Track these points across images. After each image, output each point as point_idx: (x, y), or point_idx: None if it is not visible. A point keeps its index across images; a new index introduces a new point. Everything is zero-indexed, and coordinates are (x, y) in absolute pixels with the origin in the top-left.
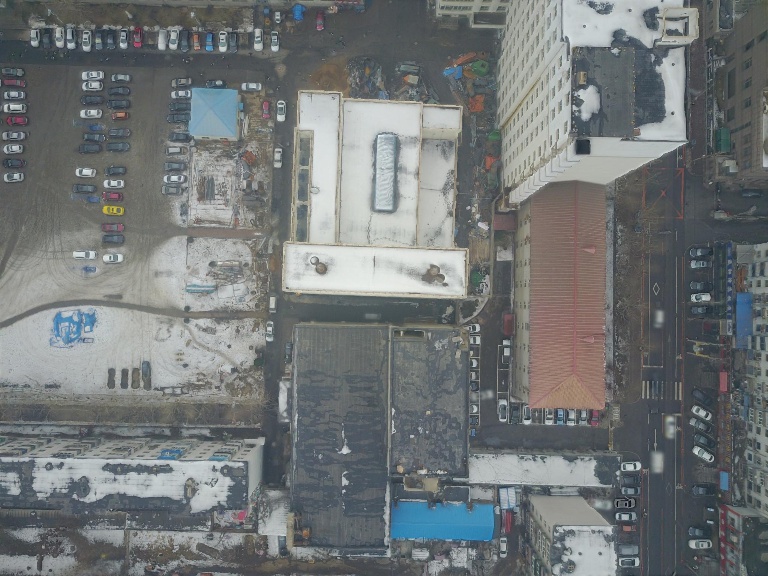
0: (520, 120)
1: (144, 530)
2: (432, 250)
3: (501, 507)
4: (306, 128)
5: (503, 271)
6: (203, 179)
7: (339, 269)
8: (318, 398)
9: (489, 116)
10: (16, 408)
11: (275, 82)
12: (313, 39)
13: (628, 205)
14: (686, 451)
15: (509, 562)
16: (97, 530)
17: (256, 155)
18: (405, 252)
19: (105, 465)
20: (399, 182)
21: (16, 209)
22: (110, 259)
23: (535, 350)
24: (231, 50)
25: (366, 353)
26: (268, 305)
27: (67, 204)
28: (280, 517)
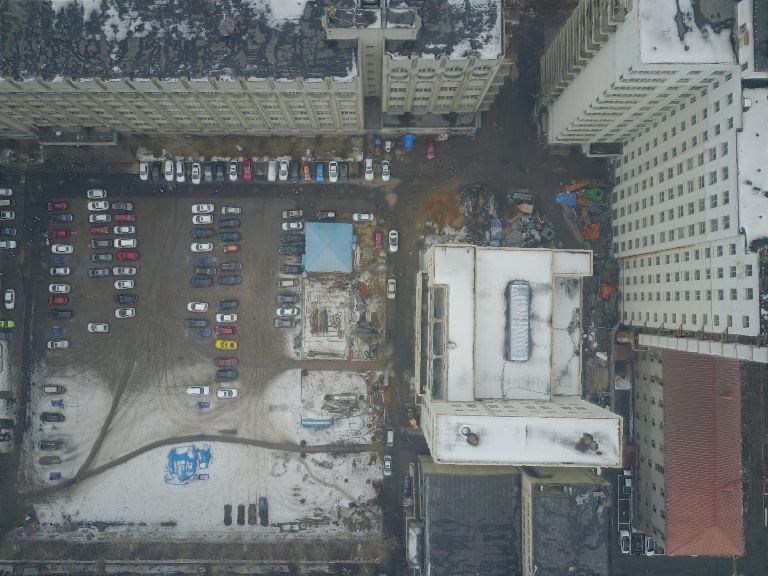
0: (655, 267)
1: None
2: (585, 419)
3: None
4: (441, 282)
5: (621, 400)
6: (316, 311)
7: (491, 439)
8: (451, 547)
9: (604, 243)
10: (132, 546)
11: (386, 211)
12: (423, 167)
13: None
14: None
15: None
16: None
17: (369, 285)
18: (557, 421)
19: None
20: (532, 330)
21: (128, 344)
22: (225, 395)
23: (672, 497)
24: (342, 180)
25: (498, 500)
26: (385, 439)
27: (179, 339)
28: None
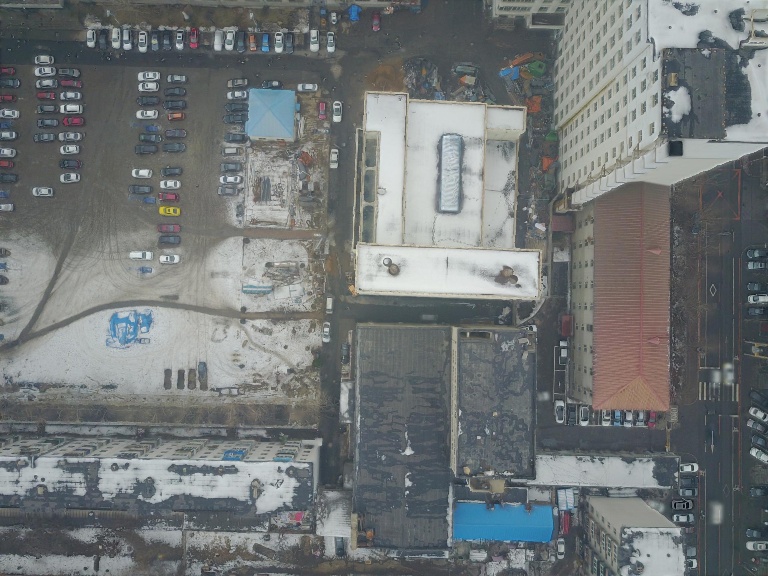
0: (586, 121)
1: (202, 531)
2: (505, 251)
3: (559, 508)
4: (373, 129)
5: (560, 272)
6: (259, 180)
7: (412, 270)
8: (381, 399)
9: (546, 117)
10: (72, 408)
11: (331, 83)
12: (369, 40)
13: (686, 206)
14: (743, 453)
15: (566, 563)
16: (154, 531)
17: (312, 156)
18: (478, 253)
19: (170, 466)
20: (463, 183)
21: (72, 210)
22: (167, 260)
23: (599, 351)
24: (287, 51)
25: (429, 354)
26: (325, 306)
27: (123, 205)
28: (338, 518)
